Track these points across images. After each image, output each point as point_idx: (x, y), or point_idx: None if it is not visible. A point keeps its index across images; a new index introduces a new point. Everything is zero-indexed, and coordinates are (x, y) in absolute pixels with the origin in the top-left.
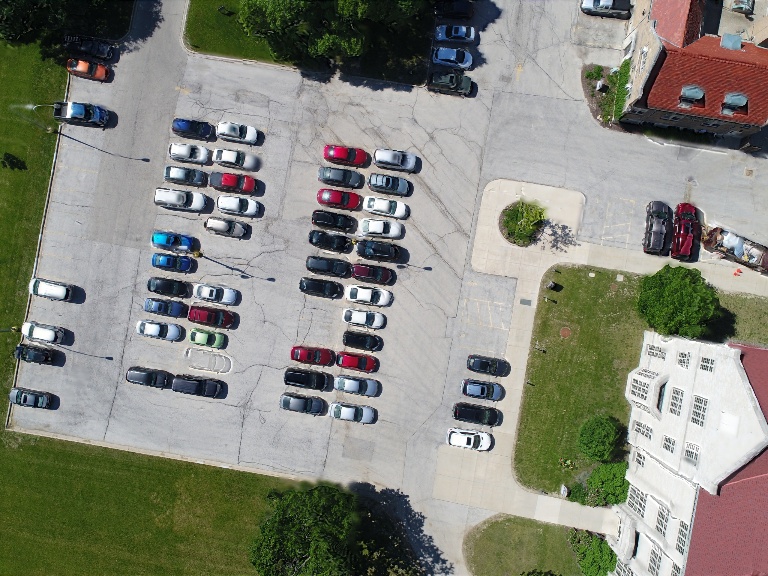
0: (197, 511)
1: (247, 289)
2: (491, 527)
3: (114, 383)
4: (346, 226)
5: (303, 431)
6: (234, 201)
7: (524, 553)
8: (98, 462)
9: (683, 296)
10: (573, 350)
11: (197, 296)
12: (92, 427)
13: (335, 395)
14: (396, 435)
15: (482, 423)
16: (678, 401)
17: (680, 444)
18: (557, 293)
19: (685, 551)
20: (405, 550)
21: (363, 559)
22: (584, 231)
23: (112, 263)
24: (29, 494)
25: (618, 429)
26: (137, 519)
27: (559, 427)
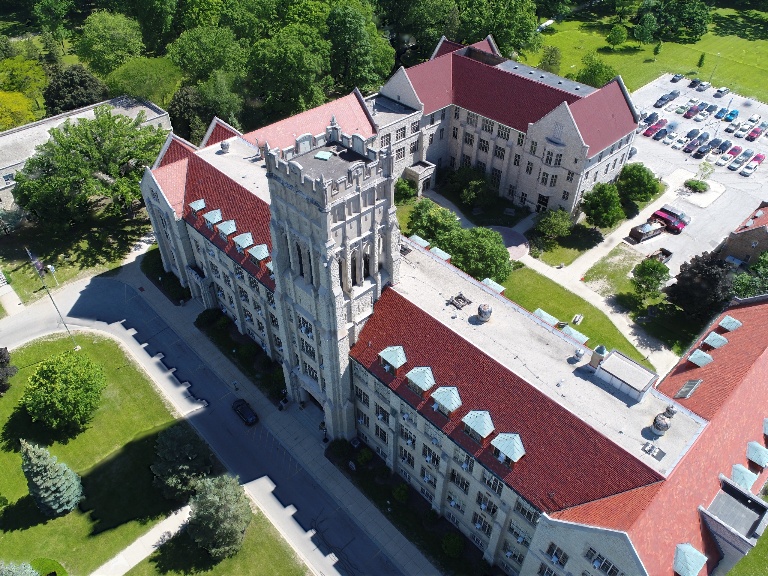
0: None
1: None
2: None
3: None
4: (720, 148)
5: None
6: (747, 127)
7: None
8: None
9: None
10: None
11: None
12: (658, 84)
13: None
14: None
15: None
16: None
17: None
18: None
19: None
20: None
21: None
22: None
23: None
24: None
25: None
26: None
27: None
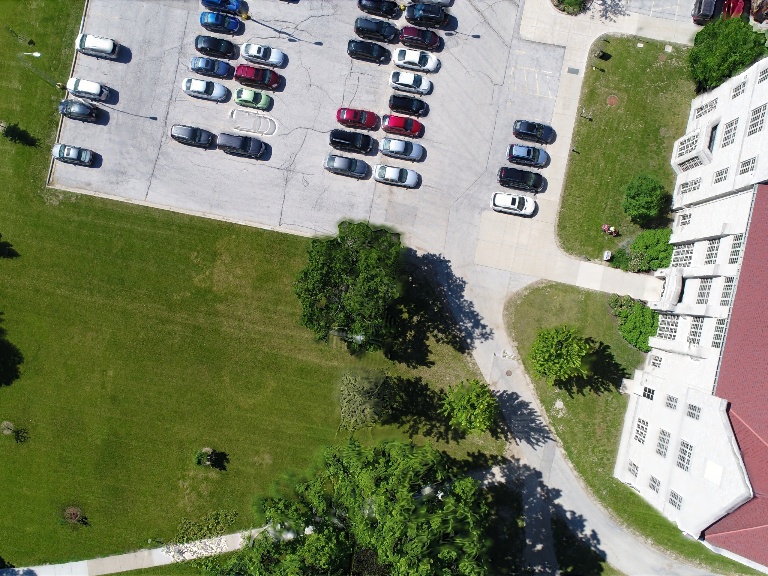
0: (237, 272)
1: (294, 52)
2: (532, 293)
3: (157, 143)
4: None
5: (346, 195)
6: None
7: (565, 319)
8: (139, 220)
9: (738, 36)
10: (620, 118)
11: (244, 54)
12: (134, 186)
13: (379, 160)
14: (439, 200)
15: (527, 185)
16: (732, 131)
17: (734, 167)
18: (605, 62)
19: (740, 257)
20: (445, 315)
21: (403, 323)
22: (633, 2)
23: (159, 24)
24: (68, 251)
25: (663, 196)
26: (176, 278)
27: (603, 194)
